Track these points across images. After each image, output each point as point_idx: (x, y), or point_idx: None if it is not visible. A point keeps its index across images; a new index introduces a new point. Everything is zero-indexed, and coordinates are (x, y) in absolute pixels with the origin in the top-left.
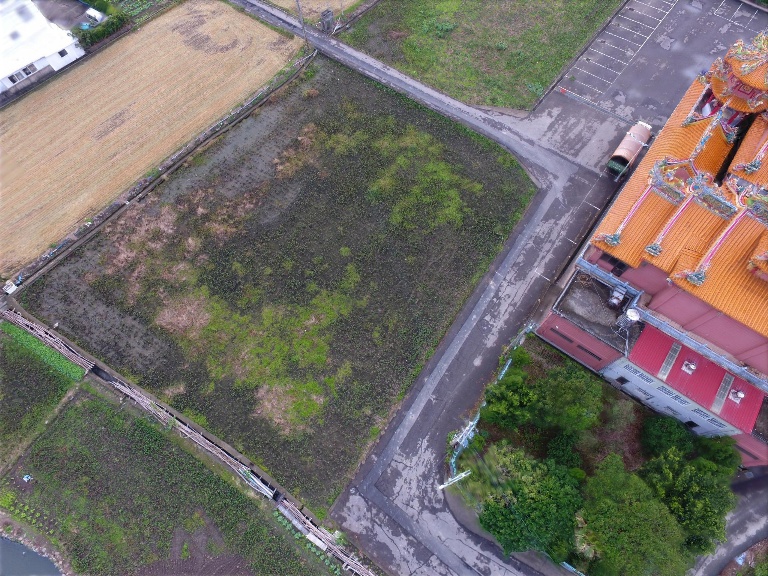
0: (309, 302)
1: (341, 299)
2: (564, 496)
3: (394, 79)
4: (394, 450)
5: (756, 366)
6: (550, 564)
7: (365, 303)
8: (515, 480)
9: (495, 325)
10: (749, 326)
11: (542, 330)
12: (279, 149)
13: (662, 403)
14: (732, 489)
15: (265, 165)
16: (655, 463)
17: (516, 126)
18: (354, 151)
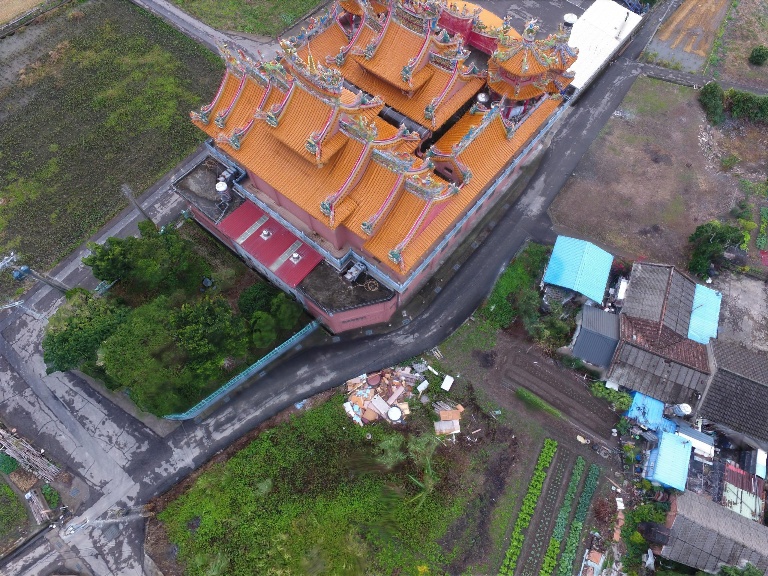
0: (4, 187)
1: (33, 186)
2: (105, 326)
3: (156, 5)
4: (29, 306)
5: (322, 234)
6: (128, 399)
7: (54, 190)
8: (78, 316)
9: (161, 211)
10: (268, 183)
11: (195, 215)
12: (29, 62)
13: (271, 275)
14: (316, 350)
15: (11, 75)
16: (196, 305)
17: (254, 49)
18: (96, 65)
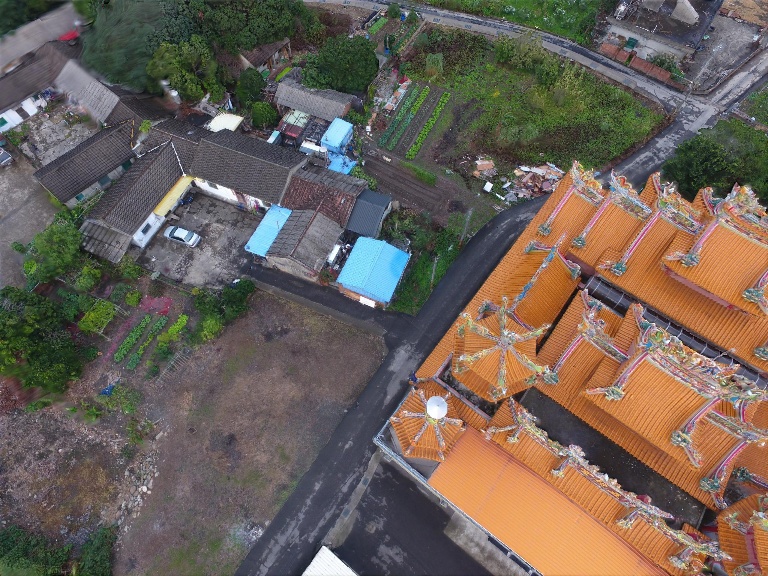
0: None
1: None
2: None
3: None
4: None
5: None
6: None
7: None
8: None
9: None
10: None
11: None
12: None
13: None
14: None
15: None
16: (725, 184)
17: None
18: None
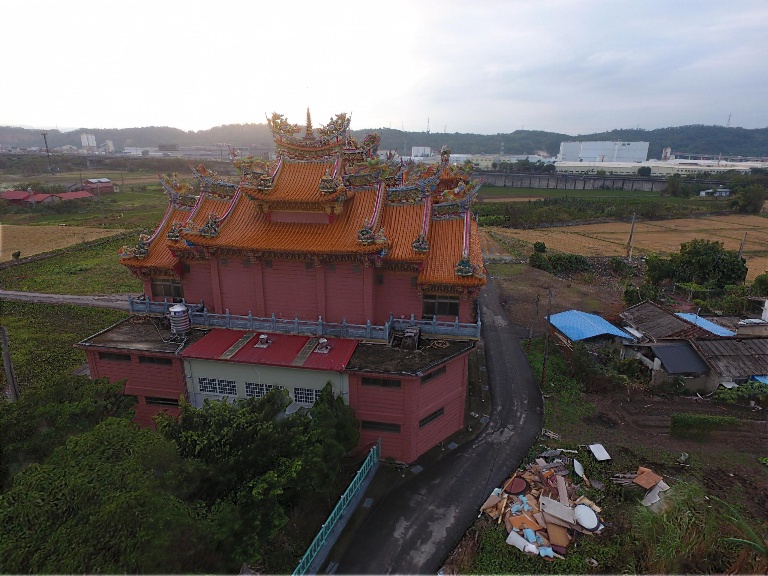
0: None
1: None
2: None
3: None
4: None
5: None
6: None
7: None
8: None
9: None
10: (272, 248)
11: None
12: None
13: None
14: (398, 493)
15: None
16: None
17: None
18: None
